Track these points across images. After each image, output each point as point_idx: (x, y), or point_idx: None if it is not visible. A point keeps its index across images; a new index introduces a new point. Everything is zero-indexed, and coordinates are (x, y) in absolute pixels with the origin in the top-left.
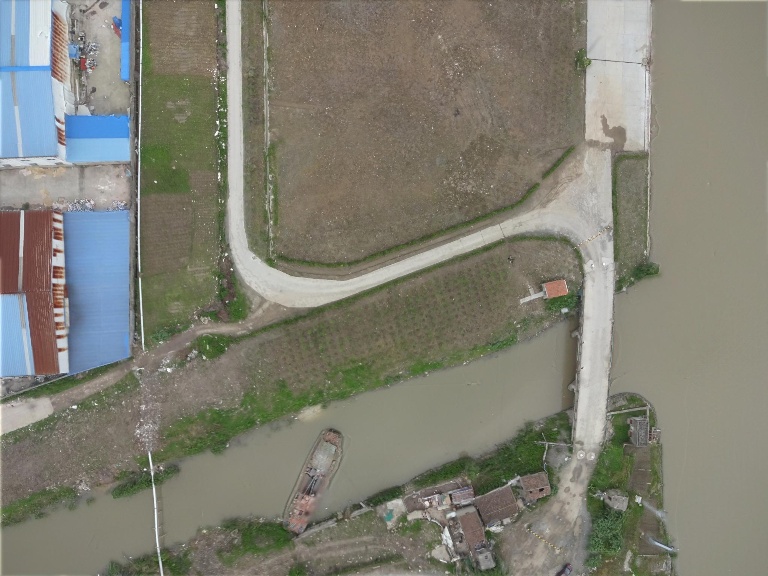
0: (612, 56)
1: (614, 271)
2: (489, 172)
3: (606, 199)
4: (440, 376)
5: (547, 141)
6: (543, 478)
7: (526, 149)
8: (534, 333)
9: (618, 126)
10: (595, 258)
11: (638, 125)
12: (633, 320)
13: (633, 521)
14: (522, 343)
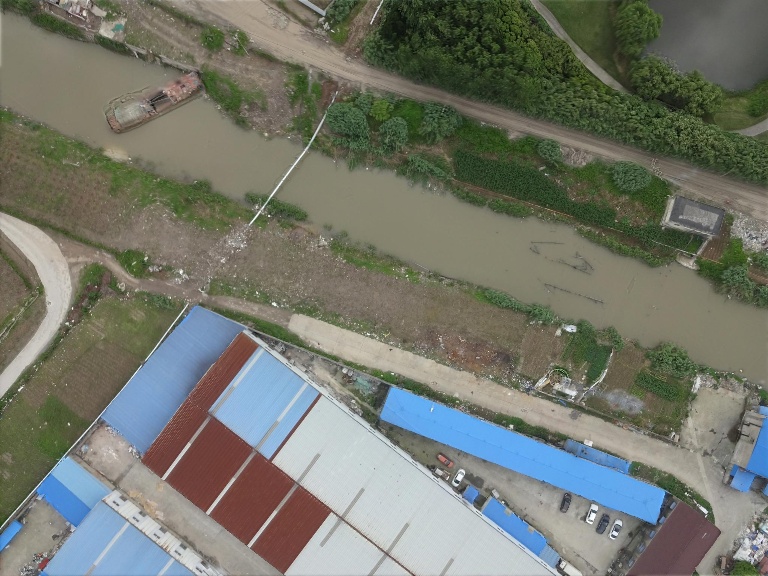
0: None
1: None
2: None
3: None
4: None
5: None
6: None
7: None
8: None
9: None
10: None
11: None
12: None
13: None
14: None
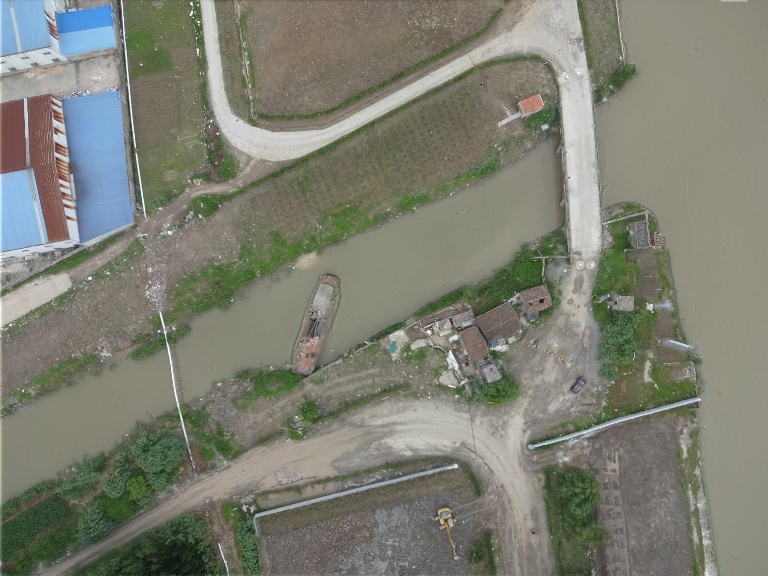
0: None
1: (589, 78)
2: (451, 6)
3: (572, 12)
4: (428, 210)
5: None
6: (542, 289)
7: None
8: (517, 155)
9: None
10: (568, 70)
11: None
12: (617, 126)
13: (647, 329)
14: (507, 167)
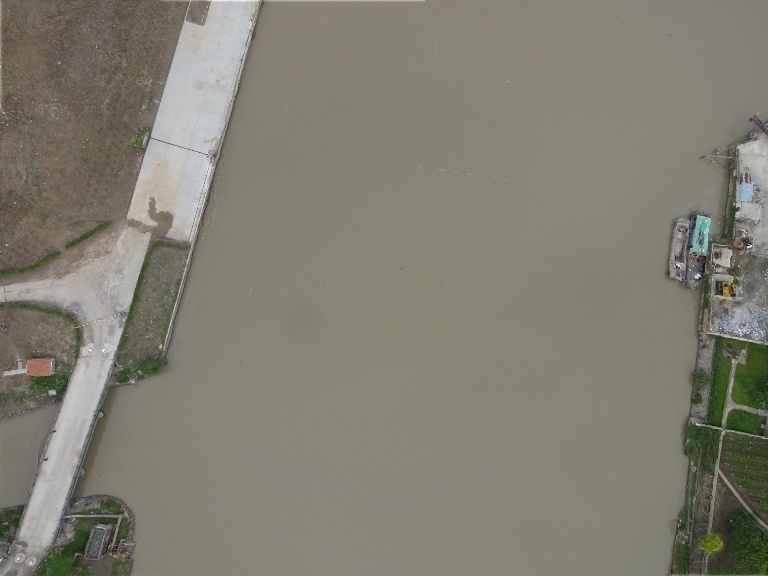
0: (178, 141)
1: (112, 360)
2: (8, 230)
3: (130, 283)
4: None
5: (83, 211)
6: None
7: (57, 214)
8: (16, 411)
9: (166, 211)
10: (98, 342)
11: (187, 215)
12: (126, 417)
13: None
14: None
